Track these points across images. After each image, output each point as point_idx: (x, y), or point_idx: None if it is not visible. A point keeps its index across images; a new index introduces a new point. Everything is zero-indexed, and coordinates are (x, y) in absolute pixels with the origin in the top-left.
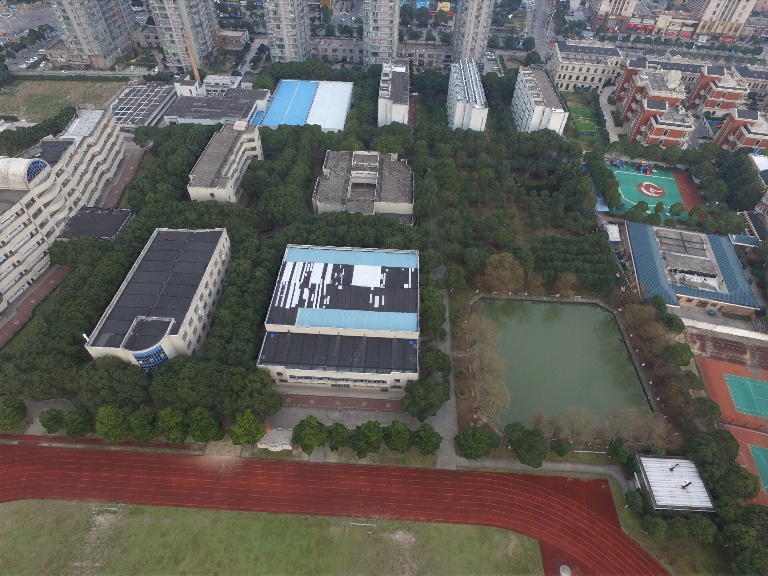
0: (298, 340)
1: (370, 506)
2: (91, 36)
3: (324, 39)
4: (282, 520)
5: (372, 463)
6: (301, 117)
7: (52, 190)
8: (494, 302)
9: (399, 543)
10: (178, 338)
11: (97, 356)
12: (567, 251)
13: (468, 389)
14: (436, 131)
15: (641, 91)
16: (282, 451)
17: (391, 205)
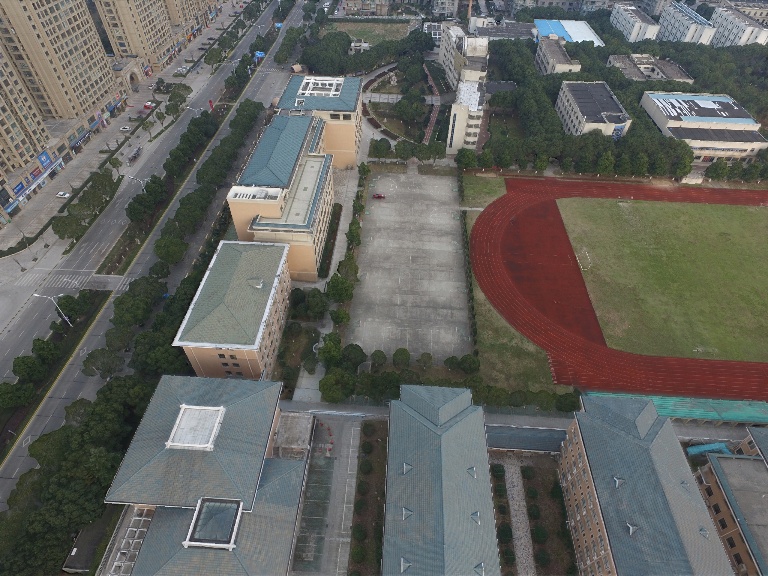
0: (687, 130)
1: (763, 202)
2: None
3: None
4: (719, 206)
5: (750, 189)
6: (568, 39)
7: None
8: None
9: None
10: None
11: (586, 131)
12: None
13: None
14: (679, 44)
15: None
16: (696, 184)
17: None
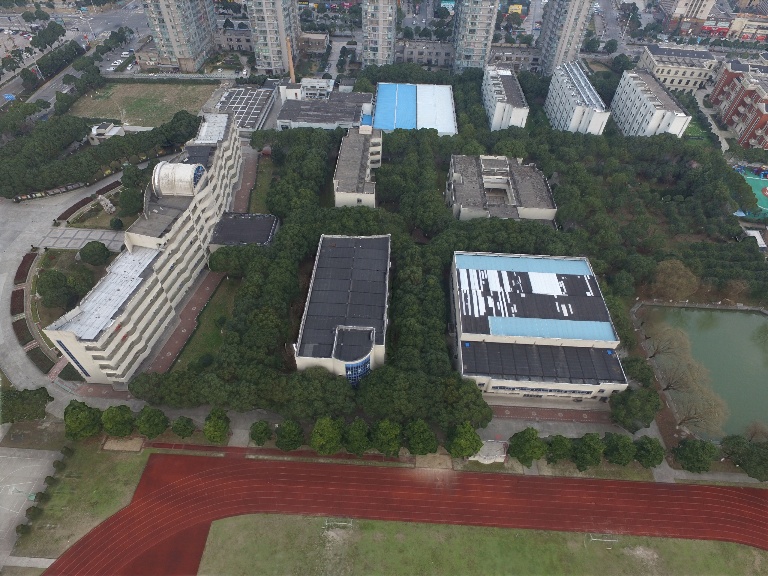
0: (494, 349)
1: (601, 521)
2: (184, 39)
3: (408, 42)
4: (516, 535)
5: (588, 476)
6: (411, 121)
7: (209, 196)
8: (651, 309)
9: (642, 559)
10: (383, 348)
11: (302, 366)
12: (721, 257)
13: (661, 399)
14: (557, 135)
15: (750, 95)
16: (493, 463)
17: (533, 210)
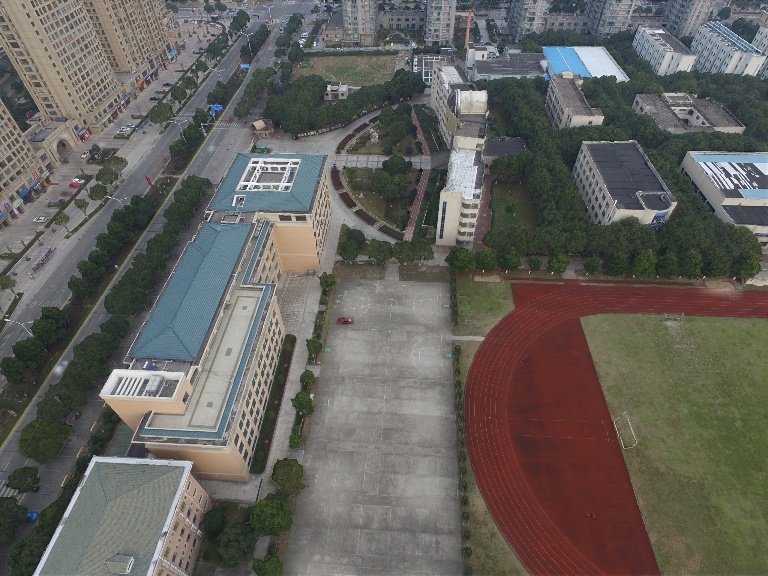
0: (749, 210)
1: None
2: (369, 17)
3: None
4: None
5: None
6: (585, 73)
7: None
8: None
9: None
10: (675, 205)
11: (617, 219)
12: None
13: None
14: (721, 77)
15: None
16: (765, 286)
17: (725, 129)
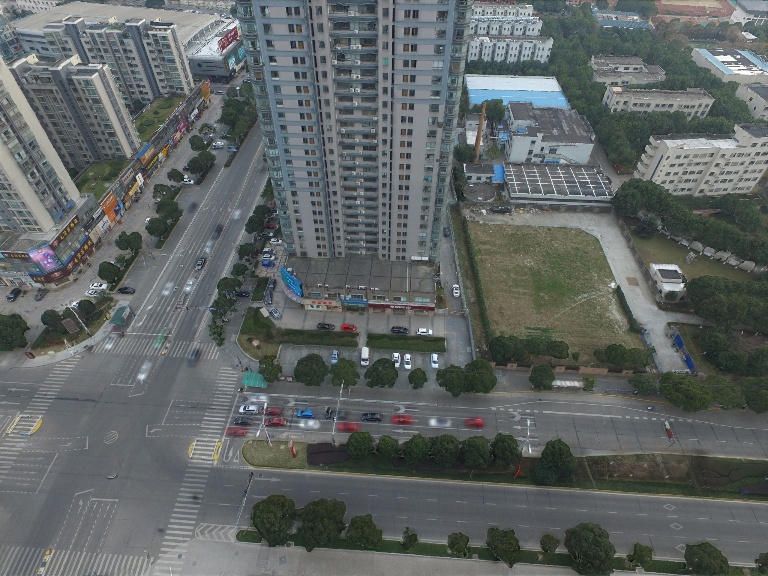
0: None
1: None
2: None
3: None
4: None
5: None
6: (542, 93)
7: None
8: None
9: None
10: None
11: None
12: None
13: None
14: None
15: None
16: None
17: None
